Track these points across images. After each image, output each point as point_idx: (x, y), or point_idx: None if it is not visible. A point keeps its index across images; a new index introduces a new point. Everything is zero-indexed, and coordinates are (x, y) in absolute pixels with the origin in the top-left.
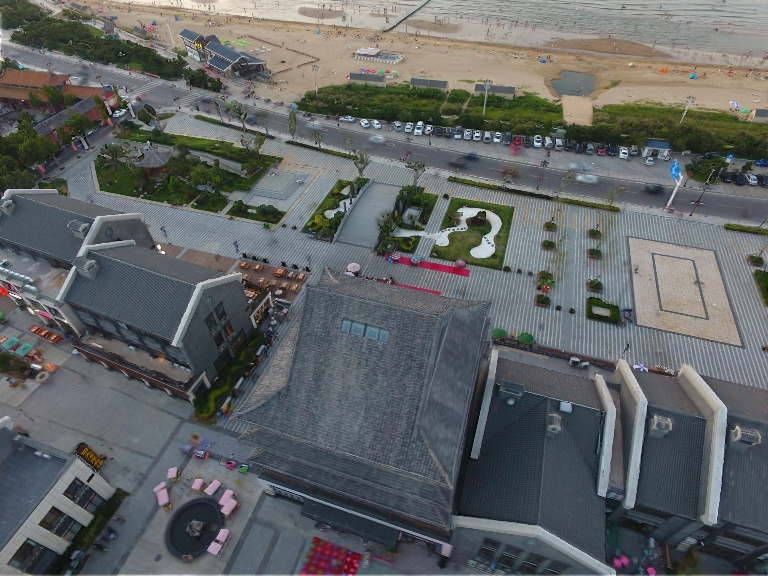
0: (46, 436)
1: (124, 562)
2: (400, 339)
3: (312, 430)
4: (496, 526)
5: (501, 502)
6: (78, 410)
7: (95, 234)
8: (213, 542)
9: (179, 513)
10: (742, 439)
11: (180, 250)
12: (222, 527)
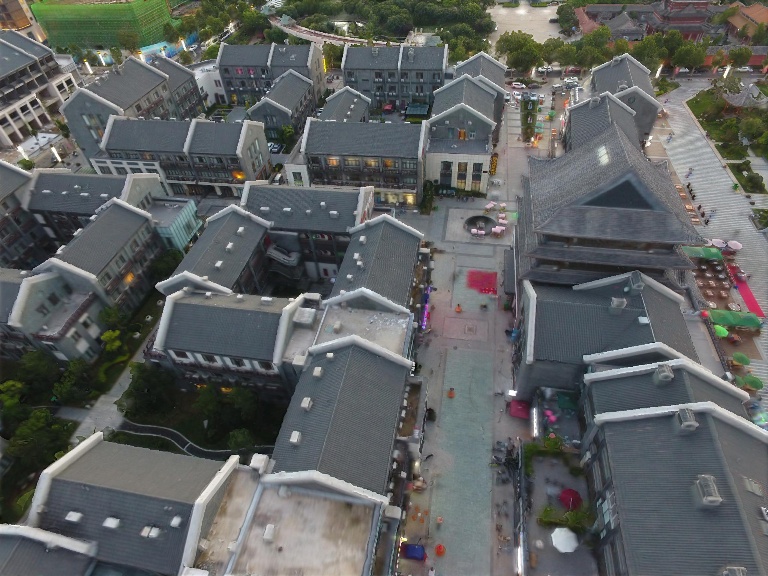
0: (499, 162)
1: (456, 208)
2: (607, 167)
3: (537, 180)
4: (529, 287)
5: (547, 293)
6: (518, 165)
7: (624, 94)
8: (477, 230)
9: (485, 217)
10: (680, 412)
11: (664, 155)
12: (486, 235)
